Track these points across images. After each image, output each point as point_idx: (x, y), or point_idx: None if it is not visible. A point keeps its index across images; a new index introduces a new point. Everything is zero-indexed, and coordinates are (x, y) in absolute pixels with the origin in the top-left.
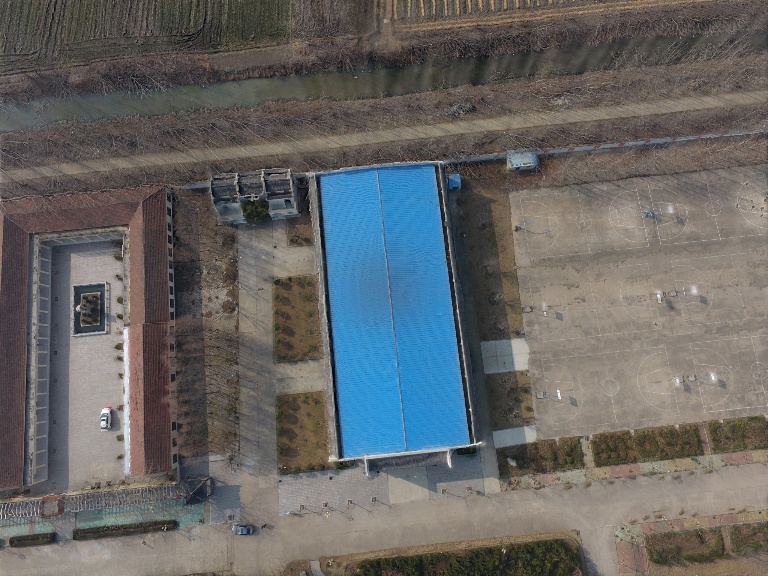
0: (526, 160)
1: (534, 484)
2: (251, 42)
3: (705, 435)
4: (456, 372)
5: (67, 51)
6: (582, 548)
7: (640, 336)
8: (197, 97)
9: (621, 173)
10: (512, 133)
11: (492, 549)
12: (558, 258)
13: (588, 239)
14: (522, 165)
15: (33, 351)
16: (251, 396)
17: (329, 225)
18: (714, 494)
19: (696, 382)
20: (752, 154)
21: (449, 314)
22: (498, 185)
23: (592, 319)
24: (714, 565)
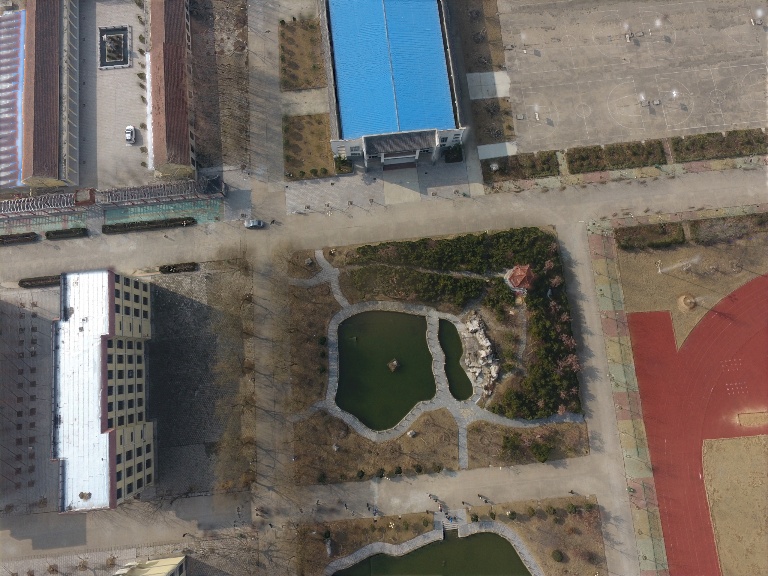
0: None
1: (515, 188)
2: None
3: (668, 148)
4: (443, 73)
5: None
6: (557, 239)
7: (610, 69)
8: None
9: None
10: None
11: None
12: (536, 6)
13: None
14: None
15: (65, 73)
16: (260, 118)
17: None
18: (676, 195)
19: (660, 106)
20: None
21: (437, 28)
22: None
23: (567, 55)
24: (675, 252)
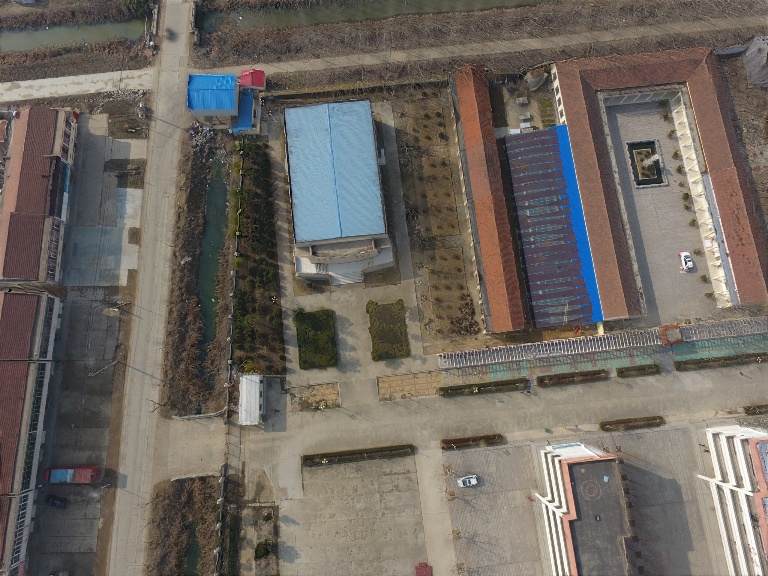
0: None
1: None
2: None
3: None
4: None
5: None
6: None
7: None
8: None
9: None
10: None
11: None
12: None
13: None
14: None
15: (620, 196)
16: None
17: None
18: None
19: None
20: None
21: None
22: None
23: None
24: None
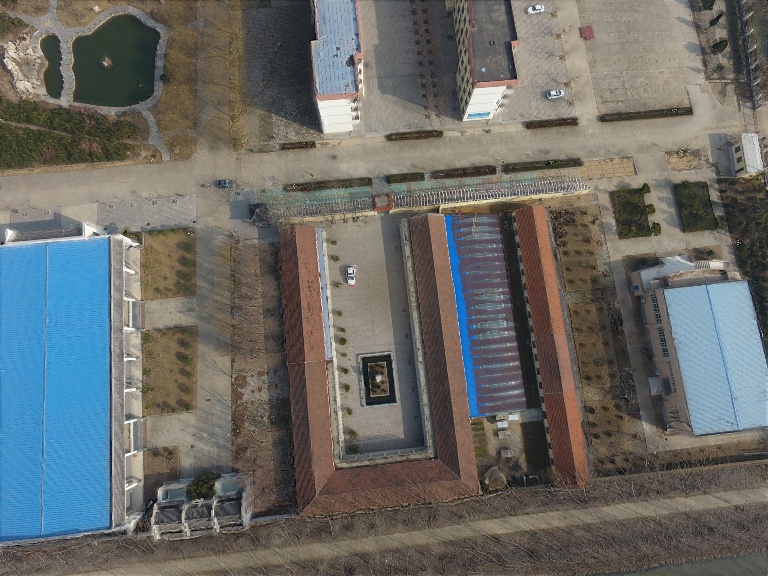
0: None
1: None
2: None
3: None
4: None
5: None
6: None
7: None
8: None
9: None
10: None
11: (8, 167)
12: None
13: None
14: None
15: (418, 337)
16: (219, 295)
17: None
18: None
19: None
20: None
21: None
22: None
23: None
24: None
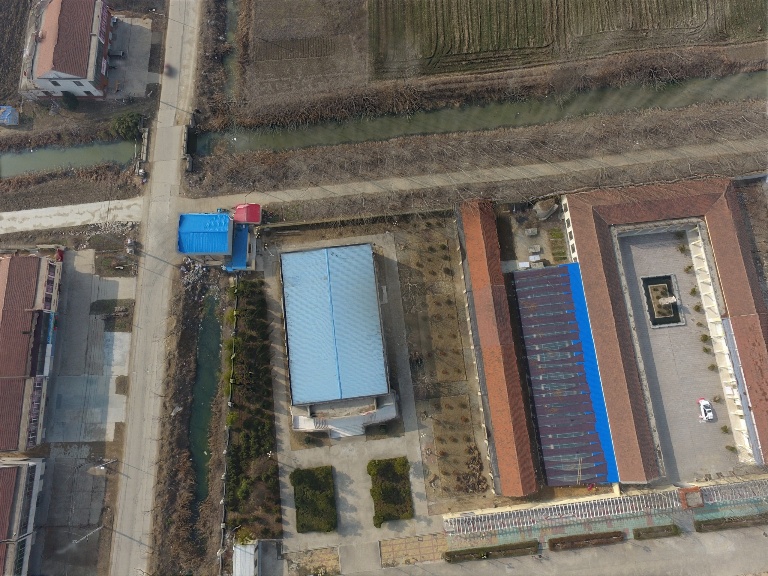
0: None
1: None
2: (760, 34)
3: None
4: None
5: (578, 44)
6: None
7: None
8: (711, 89)
9: None
10: None
11: None
12: None
13: None
14: None
15: (635, 342)
16: None
17: None
18: None
19: None
20: None
21: None
22: None
23: None
24: None
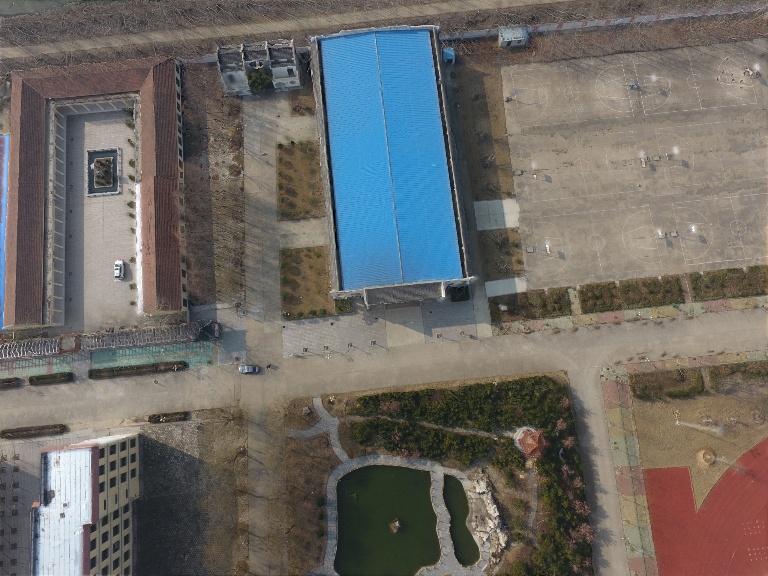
0: (517, 35)
1: (524, 329)
2: None
3: (686, 285)
4: (450, 215)
5: None
6: (569, 386)
7: (625, 197)
8: None
9: (607, 49)
10: (503, 11)
11: (484, 385)
12: (547, 126)
13: (576, 109)
14: (513, 39)
15: (50, 205)
16: (256, 250)
17: (330, 87)
18: (694, 338)
19: (678, 238)
20: (732, 32)
21: (443, 164)
22: (490, 60)
23: (579, 181)
24: (694, 401)
